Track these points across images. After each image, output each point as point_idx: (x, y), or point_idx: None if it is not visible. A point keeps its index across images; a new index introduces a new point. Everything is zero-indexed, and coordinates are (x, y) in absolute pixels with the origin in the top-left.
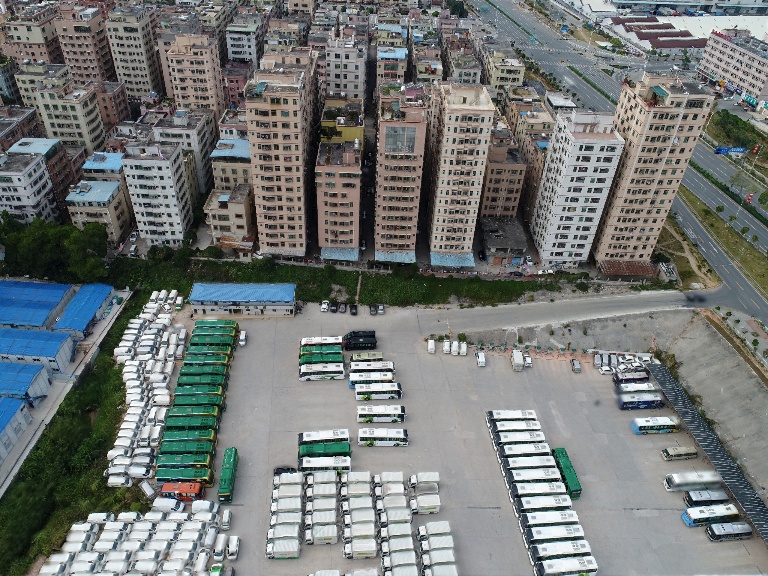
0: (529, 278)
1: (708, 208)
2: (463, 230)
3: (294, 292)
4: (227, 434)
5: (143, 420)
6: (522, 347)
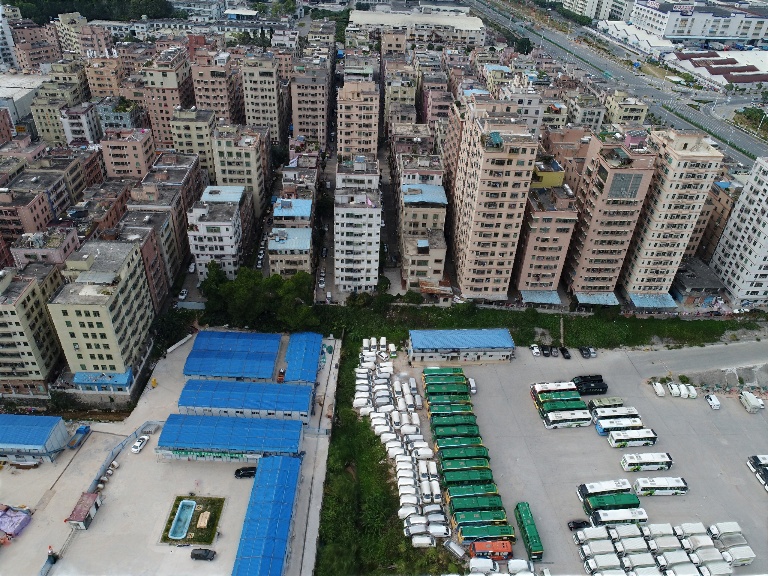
0: (728, 317)
1: None
2: (665, 271)
3: (511, 337)
4: (502, 487)
5: (416, 475)
6: (744, 388)
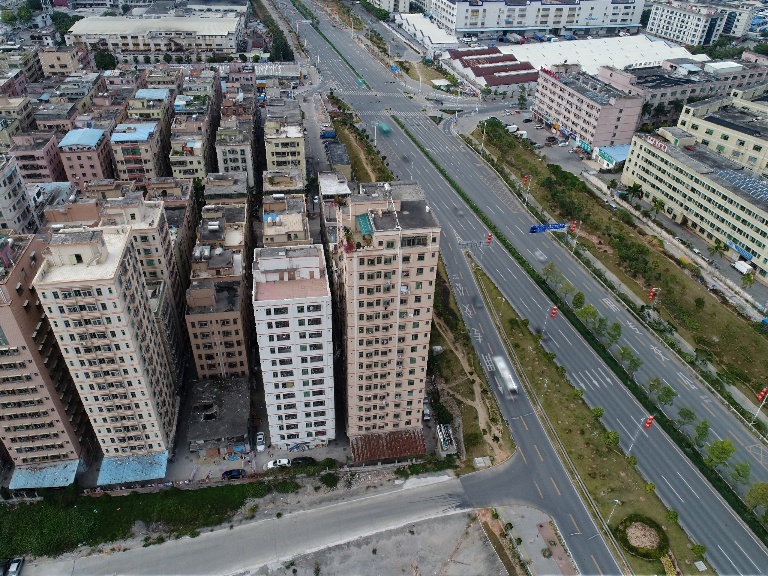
0: (251, 479)
1: (516, 316)
2: (140, 427)
3: None
4: None
5: None
6: None
